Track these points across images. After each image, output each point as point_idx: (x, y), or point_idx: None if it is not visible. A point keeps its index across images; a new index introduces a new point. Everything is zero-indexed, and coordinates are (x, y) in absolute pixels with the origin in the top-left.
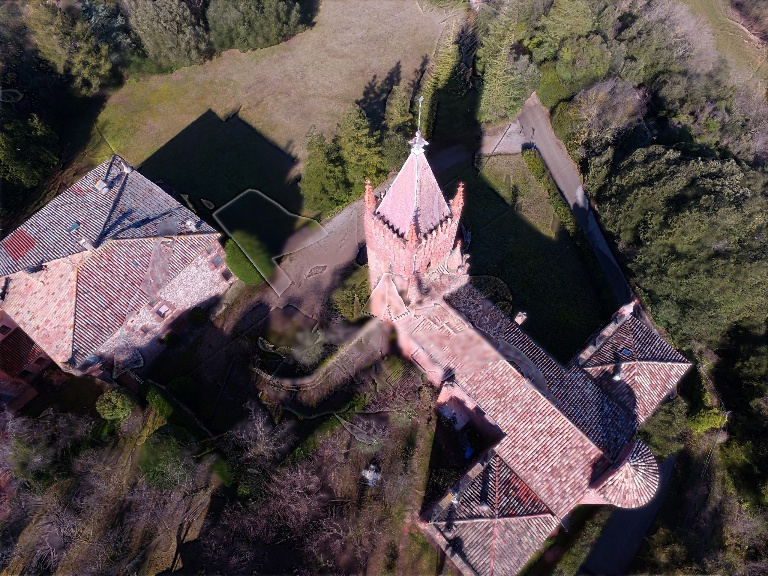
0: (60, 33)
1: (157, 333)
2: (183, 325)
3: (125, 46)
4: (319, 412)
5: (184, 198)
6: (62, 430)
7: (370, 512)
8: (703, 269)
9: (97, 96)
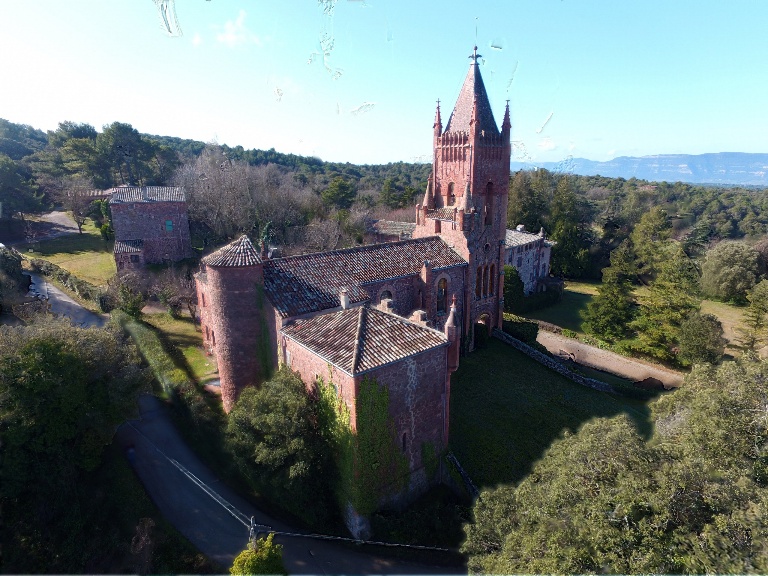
0: None
1: None
2: None
3: None
4: None
5: None
6: (367, 233)
7: None
8: None
9: None
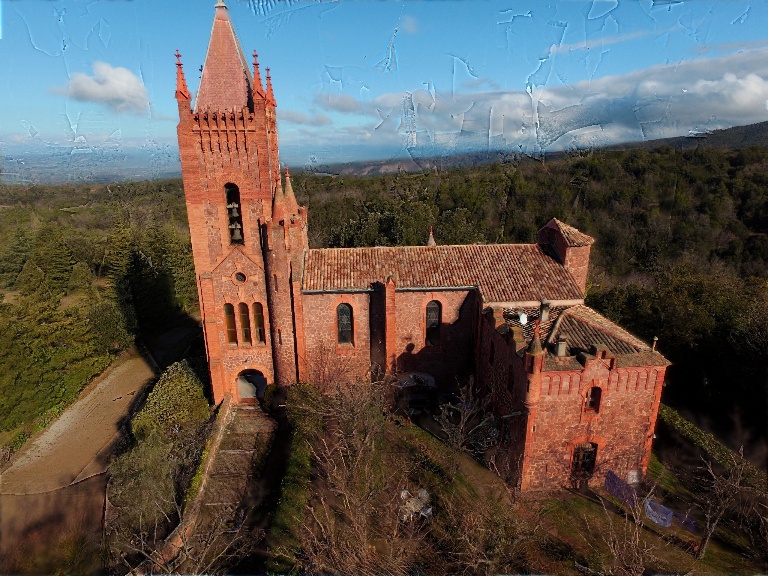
0: None
1: None
2: None
3: None
4: None
5: None
6: None
7: None
8: (437, 238)
9: None
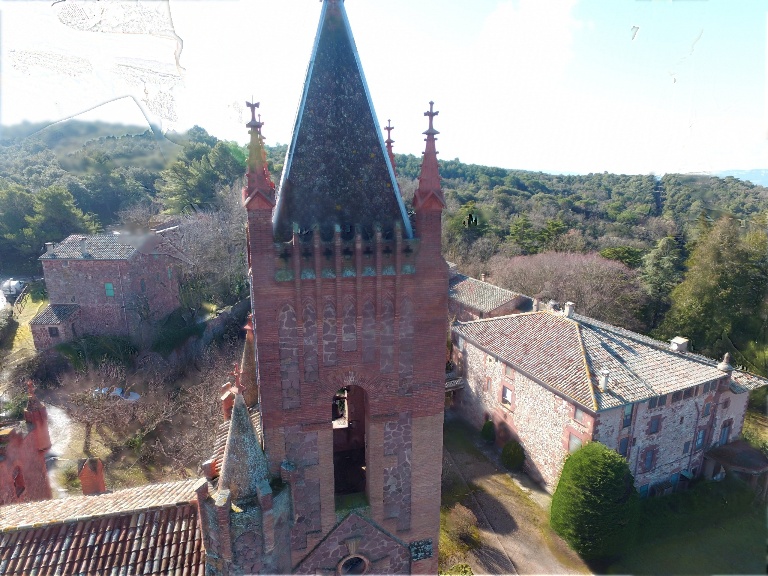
0: None
1: (491, 407)
2: None
3: None
4: None
5: None
6: None
7: (135, 486)
8: None
9: None
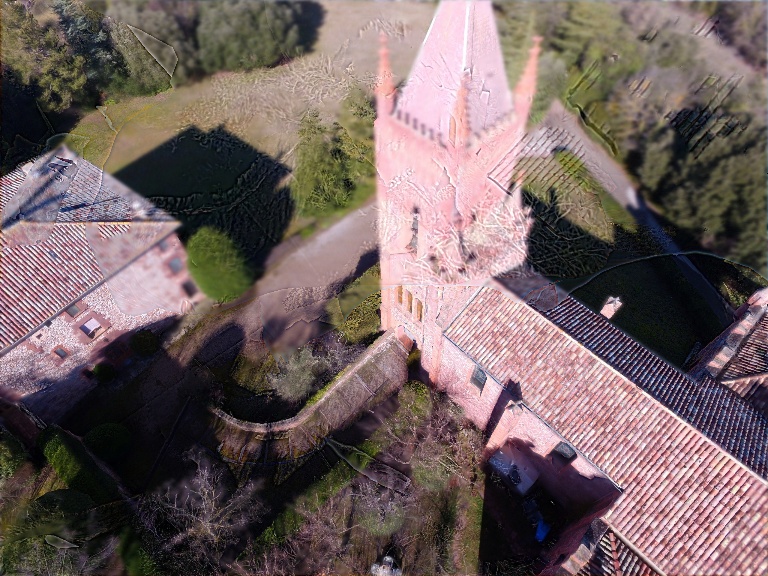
0: (27, 38)
1: (82, 361)
2: (124, 354)
3: (104, 62)
4: (247, 285)
5: (99, 108)
6: None
7: None
8: None
9: (69, 116)
